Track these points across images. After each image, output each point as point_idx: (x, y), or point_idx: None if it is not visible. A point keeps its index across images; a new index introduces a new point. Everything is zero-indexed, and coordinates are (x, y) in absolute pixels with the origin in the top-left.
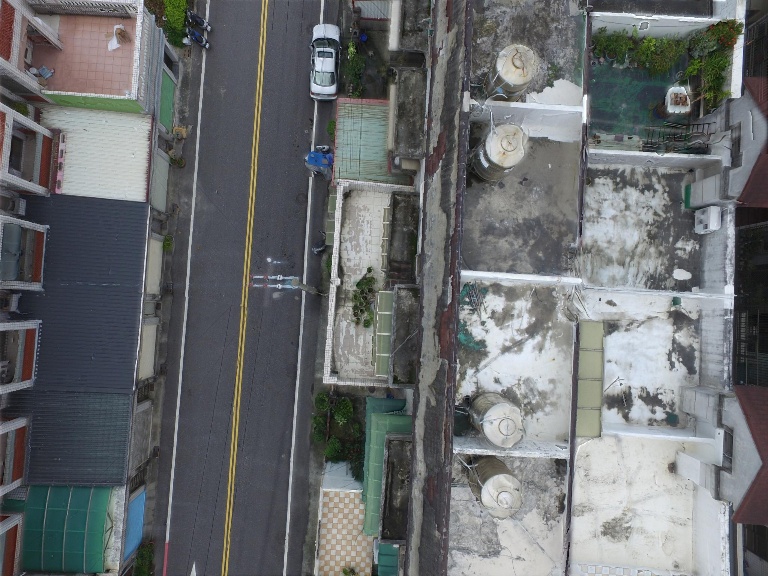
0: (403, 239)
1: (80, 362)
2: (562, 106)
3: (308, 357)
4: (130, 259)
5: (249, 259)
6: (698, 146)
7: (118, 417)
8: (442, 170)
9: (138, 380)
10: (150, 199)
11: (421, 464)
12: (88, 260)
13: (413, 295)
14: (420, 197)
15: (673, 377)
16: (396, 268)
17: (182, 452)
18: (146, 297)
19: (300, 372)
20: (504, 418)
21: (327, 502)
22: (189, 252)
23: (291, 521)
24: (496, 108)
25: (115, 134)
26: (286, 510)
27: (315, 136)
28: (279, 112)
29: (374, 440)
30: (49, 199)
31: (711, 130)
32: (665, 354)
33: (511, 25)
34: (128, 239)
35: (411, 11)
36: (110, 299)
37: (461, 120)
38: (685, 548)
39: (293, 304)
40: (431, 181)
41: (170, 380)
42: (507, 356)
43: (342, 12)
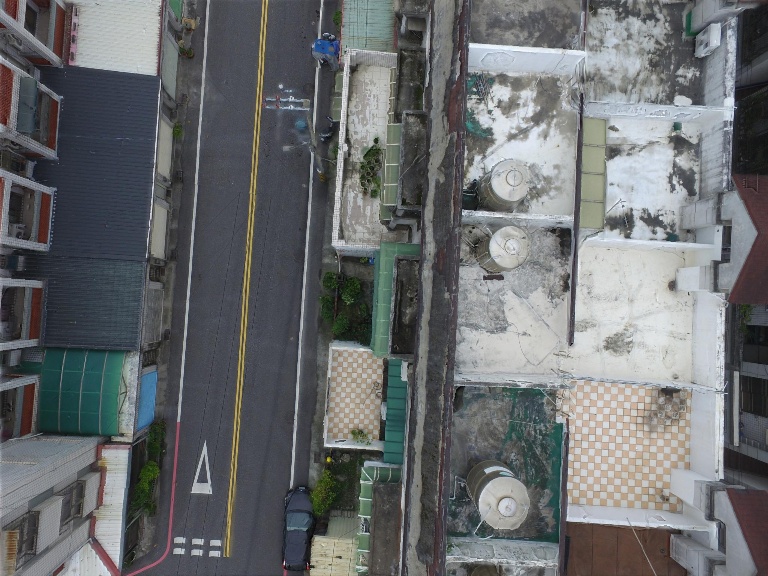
0: (410, 94)
1: (94, 229)
2: None
3: (315, 243)
4: (142, 131)
5: (257, 147)
6: None
7: (131, 283)
8: None
9: (150, 254)
10: (161, 75)
11: (430, 245)
12: (101, 131)
13: (421, 122)
14: (427, 46)
15: (674, 199)
16: None
17: (193, 335)
18: (157, 176)
19: (308, 257)
20: (511, 170)
21: (336, 366)
22: (198, 140)
23: (300, 402)
24: None
25: (126, 9)
26: (295, 391)
27: (321, 27)
28: (286, 4)
29: (383, 267)
30: (63, 70)
31: None
32: (666, 177)
33: None
34: (140, 111)
35: None
36: (123, 169)
37: None
38: (685, 361)
39: (301, 191)
40: None
41: (180, 265)
42: (513, 143)
43: None
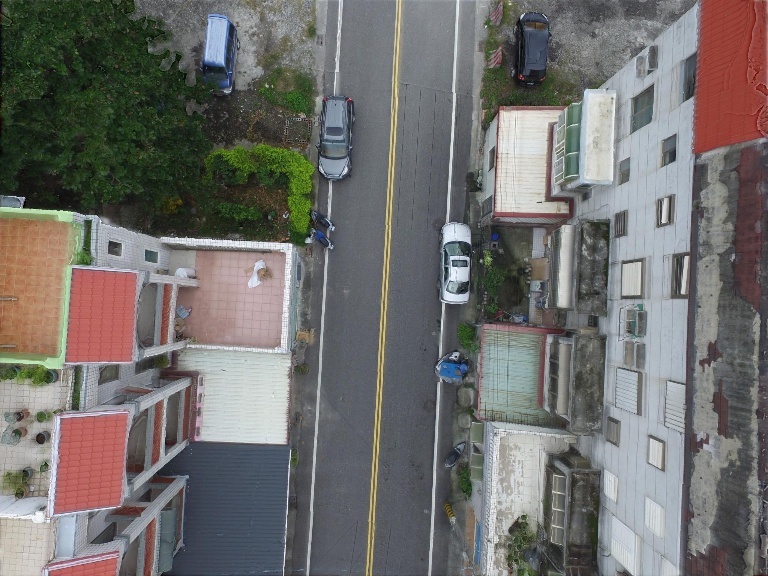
0: (582, 520)
1: None
2: None
3: (439, 574)
4: (272, 507)
5: (376, 471)
6: None
7: None
8: None
9: None
10: None
11: None
12: (229, 510)
13: None
14: (609, 489)
15: None
16: (576, 553)
17: None
18: None
19: None
20: None
21: None
22: (314, 464)
23: None
24: None
25: (254, 373)
26: None
27: (443, 338)
28: (405, 314)
29: None
30: (188, 447)
31: None
32: None
33: None
34: (269, 485)
35: (587, 272)
36: (252, 551)
37: (757, 565)
38: None
39: (422, 518)
40: None
41: None
42: None
43: (469, 205)
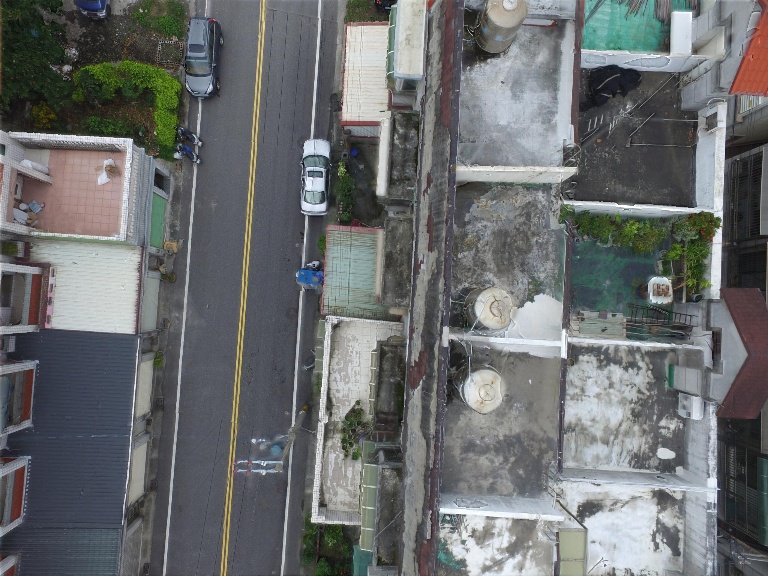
0: (390, 390)
1: (69, 497)
2: (541, 341)
3: (298, 472)
4: (119, 392)
5: (239, 374)
6: (680, 337)
7: (107, 552)
8: (422, 391)
9: (127, 508)
10: (140, 328)
11: None
12: (77, 394)
13: (397, 474)
14: None
15: (657, 558)
16: (383, 419)
17: (172, 569)
18: (136, 422)
19: (290, 488)
20: None
21: None
22: (180, 368)
23: None
24: (475, 342)
25: (105, 266)
26: None
27: (306, 250)
28: (270, 226)
29: None
30: (39, 334)
31: (693, 323)
32: (649, 535)
33: (492, 239)
34: (117, 372)
35: (398, 160)
36: (99, 433)
37: (440, 354)
38: None
39: (283, 419)
40: (412, 394)
41: (160, 496)
42: (488, 575)
43: (333, 125)
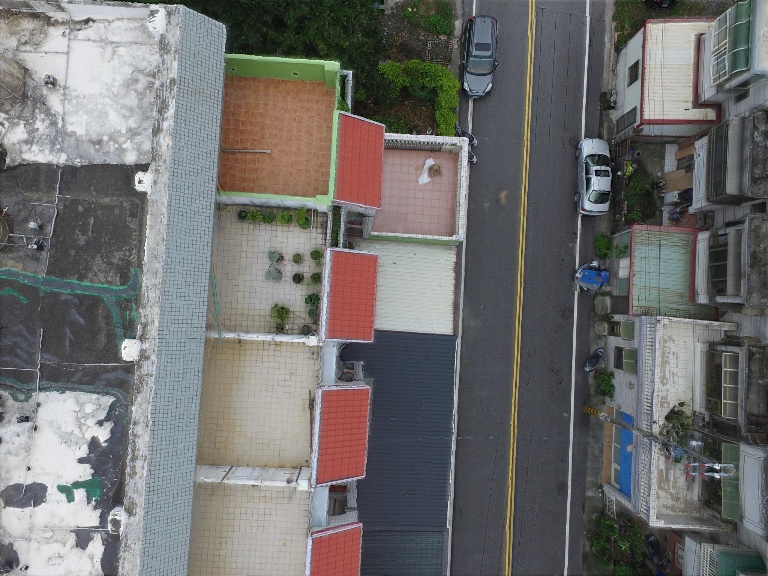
0: (758, 391)
1: (395, 500)
2: None
3: (578, 475)
4: (440, 394)
5: (518, 375)
6: None
7: (433, 555)
8: None
9: None
10: None
11: None
12: (401, 396)
13: None
14: None
15: None
16: (753, 421)
17: (455, 573)
18: None
19: (571, 490)
20: None
21: None
22: (458, 369)
23: None
24: None
25: (422, 267)
26: None
27: (579, 250)
28: (544, 226)
29: None
30: None
31: None
32: None
33: None
34: (438, 373)
35: (758, 158)
36: (422, 435)
37: None
38: None
39: (562, 421)
40: None
41: None
42: None
43: (603, 123)
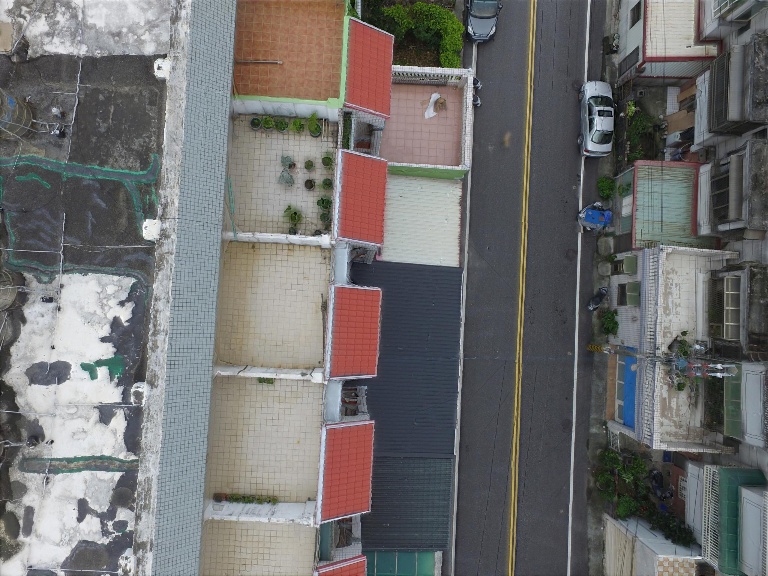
0: (760, 311)
1: (403, 427)
2: None
3: (583, 412)
4: (447, 324)
5: (523, 315)
6: None
7: (441, 482)
8: None
9: None
10: None
11: None
12: (408, 326)
13: None
14: None
15: None
16: (755, 340)
17: (462, 508)
18: None
19: (576, 427)
20: None
21: None
22: (464, 309)
23: None
24: None
25: (429, 200)
26: (566, 566)
27: (583, 192)
28: (547, 168)
29: None
30: (370, 266)
31: None
32: None
33: None
34: (444, 304)
35: (759, 83)
36: (430, 364)
37: None
38: None
39: (566, 359)
40: None
41: None
42: None
43: (605, 68)
